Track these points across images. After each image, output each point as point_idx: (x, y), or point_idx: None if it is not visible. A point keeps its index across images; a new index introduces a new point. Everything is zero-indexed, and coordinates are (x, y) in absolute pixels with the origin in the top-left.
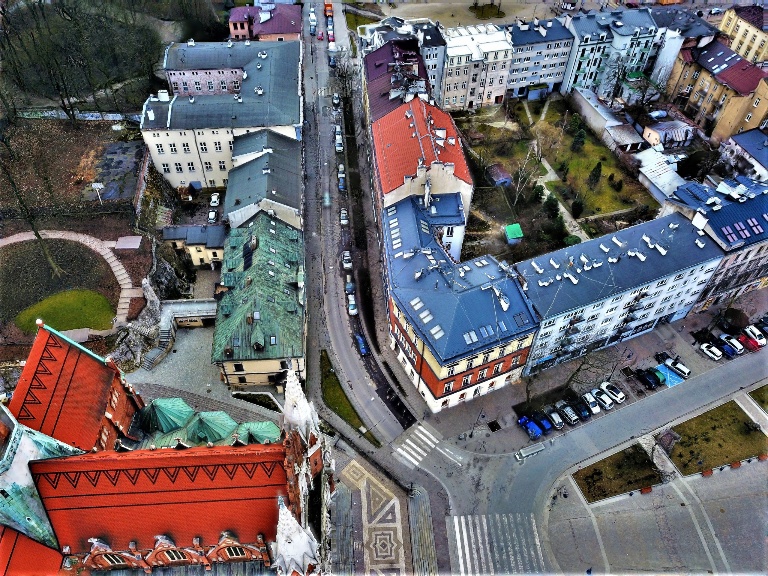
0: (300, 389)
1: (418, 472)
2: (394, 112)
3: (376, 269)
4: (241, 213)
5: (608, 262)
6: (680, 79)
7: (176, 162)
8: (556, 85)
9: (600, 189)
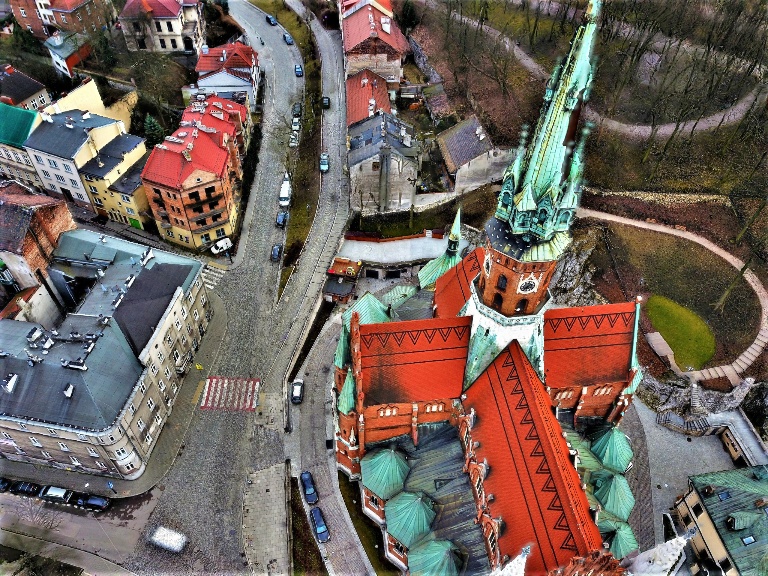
0: (671, 561)
1: None
2: None
3: None
4: None
5: None
6: None
7: None
8: None
9: None
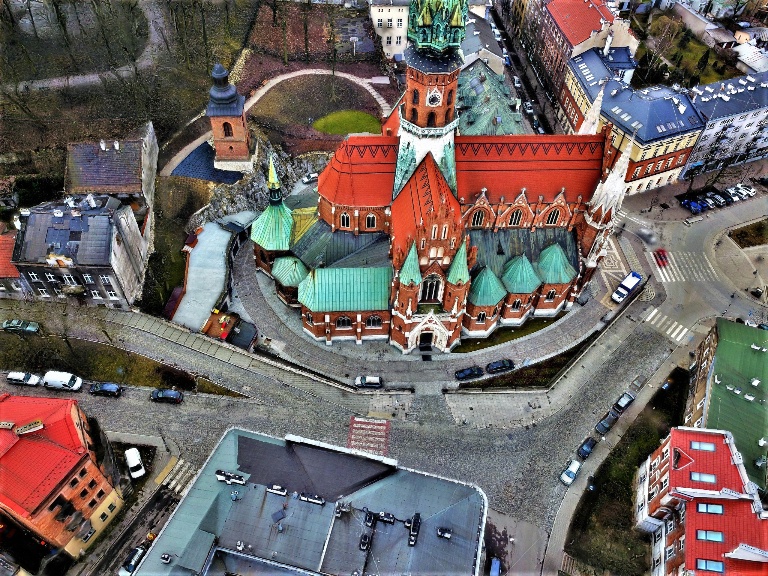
0: None
1: (618, 229)
2: None
3: (551, 115)
4: None
5: (747, 90)
6: None
7: (388, 36)
8: (657, 2)
9: (708, 72)
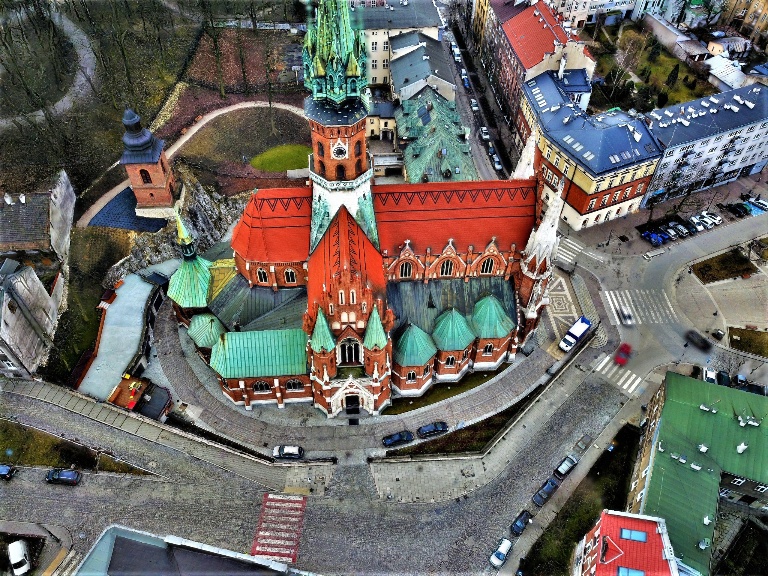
0: None
1: (572, 266)
2: (521, 14)
3: (508, 140)
4: (411, 88)
5: (710, 113)
6: (737, 3)
7: None
8: (628, 13)
9: (678, 87)
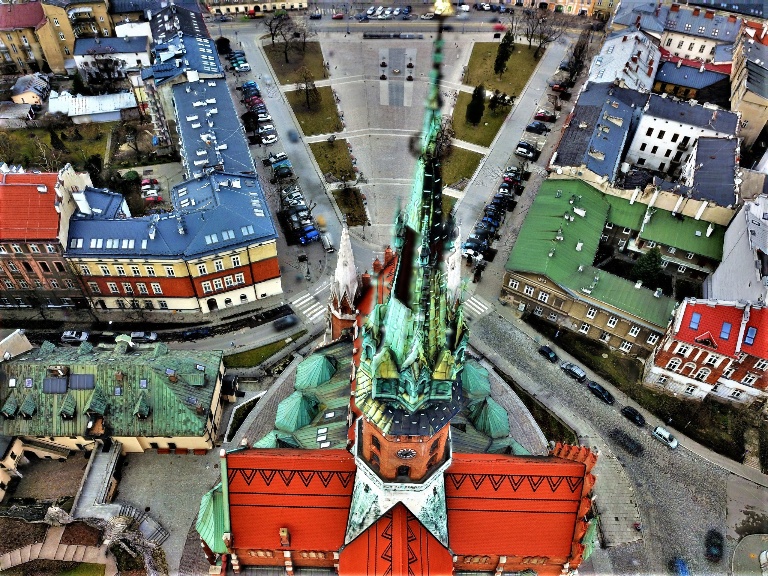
0: None
1: None
2: None
3: (99, 315)
4: None
5: None
6: None
7: None
8: None
9: (75, 146)
